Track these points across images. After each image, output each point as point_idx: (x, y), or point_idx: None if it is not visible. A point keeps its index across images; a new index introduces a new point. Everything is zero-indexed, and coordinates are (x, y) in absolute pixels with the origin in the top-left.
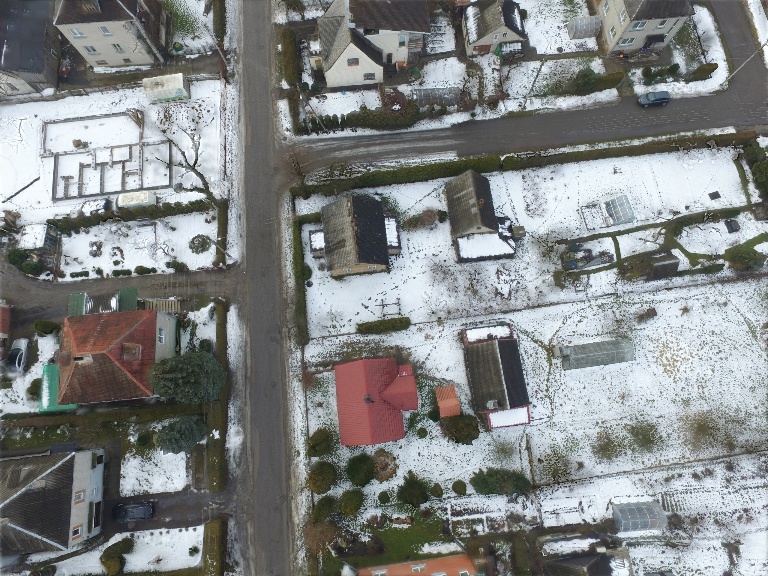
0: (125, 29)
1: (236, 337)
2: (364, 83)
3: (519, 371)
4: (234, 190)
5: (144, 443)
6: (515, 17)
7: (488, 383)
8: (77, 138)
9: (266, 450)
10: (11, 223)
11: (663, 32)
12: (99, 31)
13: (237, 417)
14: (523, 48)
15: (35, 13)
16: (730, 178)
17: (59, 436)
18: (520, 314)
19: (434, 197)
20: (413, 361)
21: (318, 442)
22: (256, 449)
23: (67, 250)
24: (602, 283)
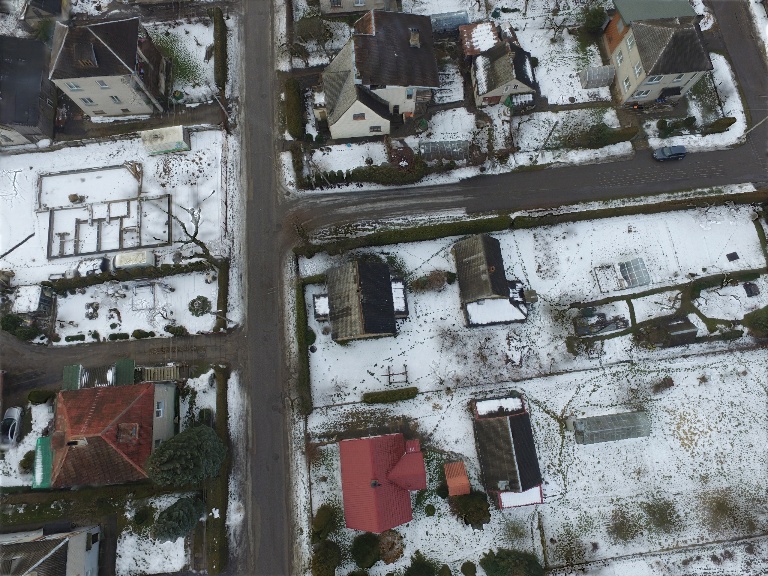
0: (123, 83)
1: (237, 406)
2: (370, 135)
3: (531, 447)
4: (235, 248)
5: (141, 521)
6: (526, 68)
7: (499, 462)
8: (73, 192)
9: (268, 528)
10: (4, 283)
11: (679, 85)
12: (96, 84)
13: (238, 492)
14: (534, 99)
15: (30, 62)
16: (749, 238)
17: (53, 511)
18: (531, 383)
19: (442, 257)
20: (420, 433)
21: (322, 528)
22: (257, 526)
23: (62, 311)
24: (616, 350)
